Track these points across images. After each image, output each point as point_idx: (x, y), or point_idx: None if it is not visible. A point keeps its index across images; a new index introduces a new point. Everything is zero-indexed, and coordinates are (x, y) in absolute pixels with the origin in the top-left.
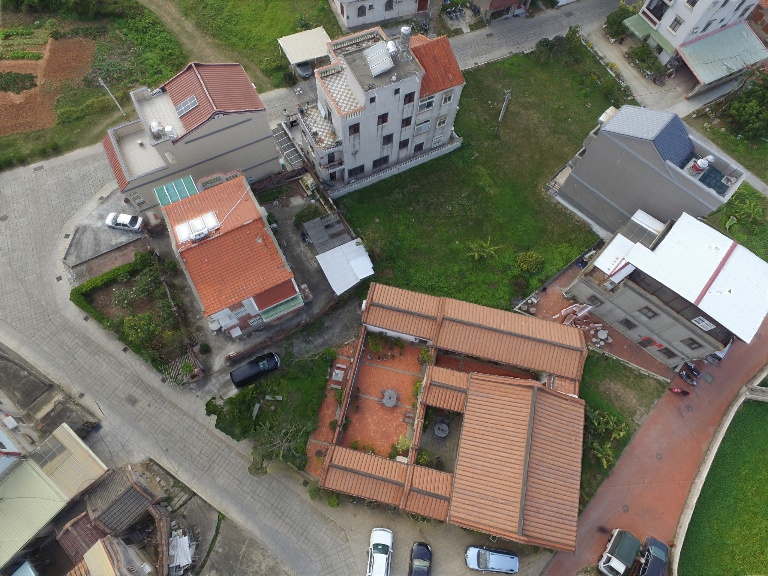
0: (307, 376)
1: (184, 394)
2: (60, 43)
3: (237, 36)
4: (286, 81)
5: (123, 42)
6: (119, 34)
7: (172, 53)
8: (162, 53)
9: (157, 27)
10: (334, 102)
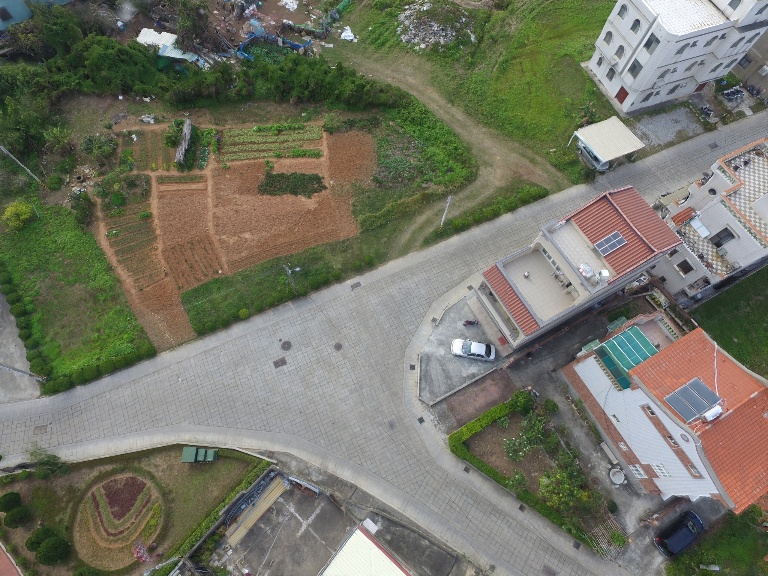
0: (735, 538)
1: (604, 563)
2: (336, 138)
3: (512, 124)
4: (590, 178)
5: (402, 135)
6: (396, 126)
7: (457, 147)
8: (448, 148)
9: (430, 117)
10: (759, 233)
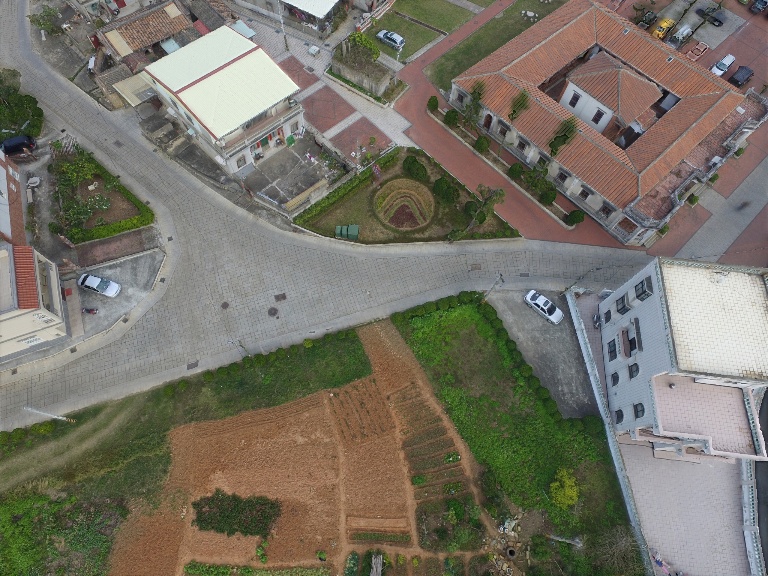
0: None
1: None
2: None
3: None
4: None
5: None
6: None
7: None
8: None
9: None
10: None
